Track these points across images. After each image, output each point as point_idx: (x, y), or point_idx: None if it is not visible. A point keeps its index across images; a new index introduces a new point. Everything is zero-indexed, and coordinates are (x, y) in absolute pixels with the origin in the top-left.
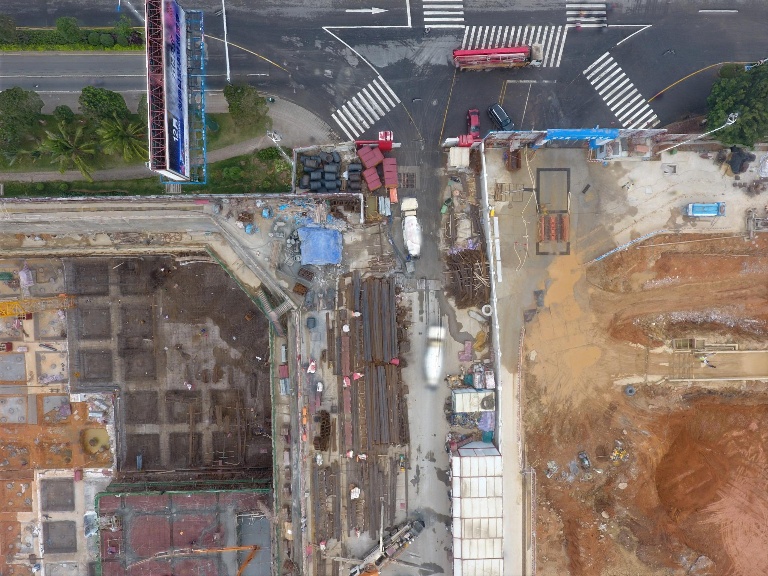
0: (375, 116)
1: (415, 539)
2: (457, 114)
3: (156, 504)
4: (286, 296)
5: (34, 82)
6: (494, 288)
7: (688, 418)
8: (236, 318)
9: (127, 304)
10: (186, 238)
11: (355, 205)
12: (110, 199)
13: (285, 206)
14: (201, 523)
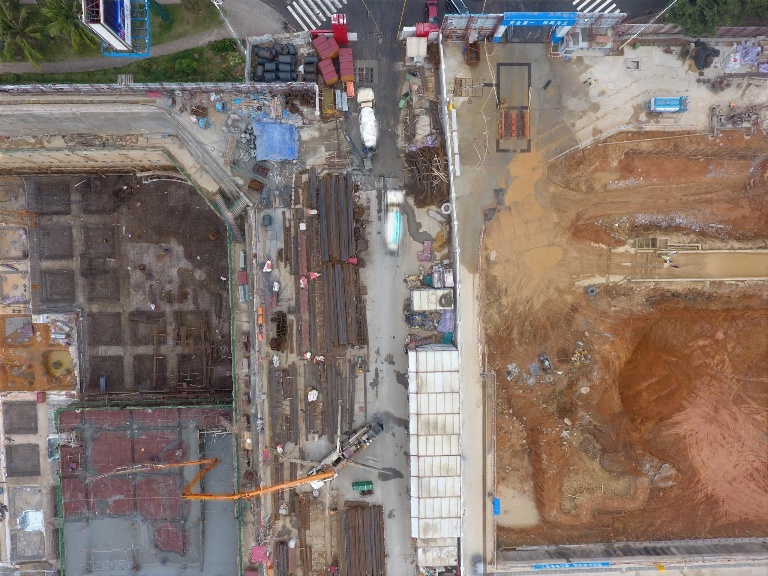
0: (332, 8)
1: (374, 442)
2: (415, 7)
3: (117, 420)
4: (241, 192)
5: None
6: (452, 183)
7: (651, 321)
8: (200, 237)
9: (89, 223)
10: (142, 141)
11: (311, 100)
12: (60, 90)
13: (239, 99)
14: (163, 440)
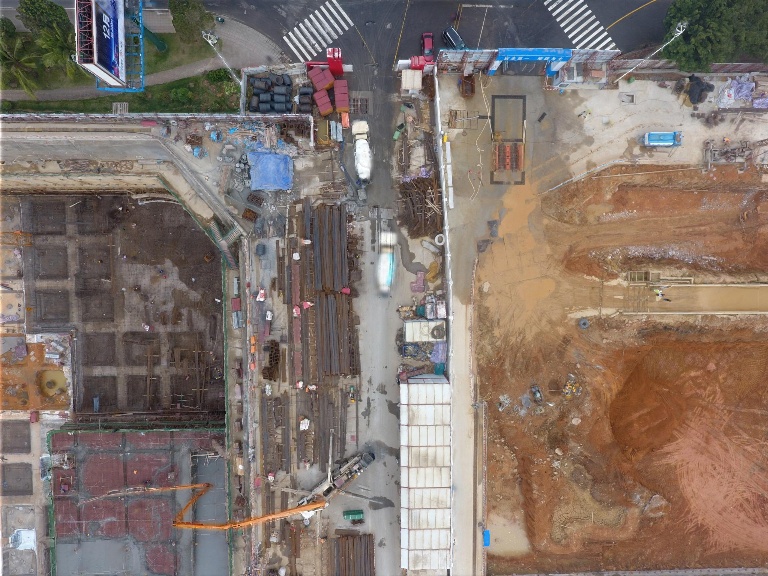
0: (327, 39)
1: (365, 471)
2: (411, 38)
3: (109, 442)
4: (235, 222)
5: None
6: (446, 215)
7: (643, 353)
8: (195, 259)
9: (84, 244)
10: (137, 167)
11: (306, 130)
12: (55, 119)
13: (234, 129)
14: (155, 462)
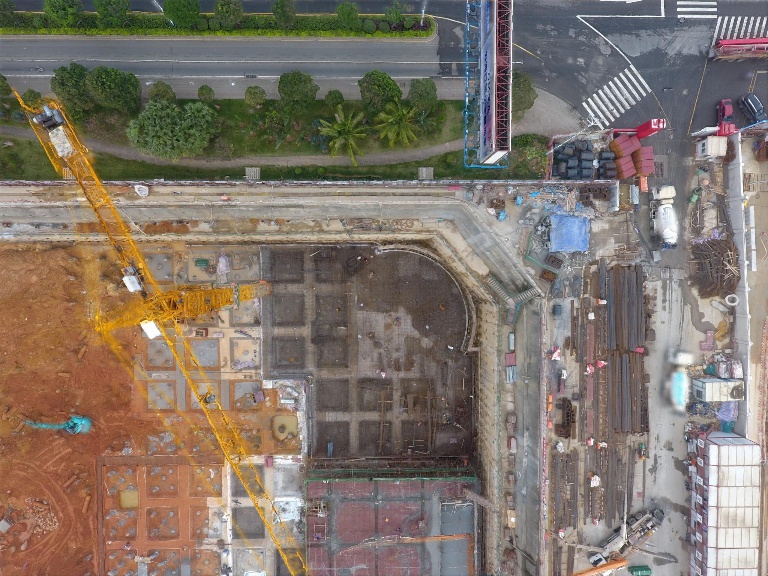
0: (625, 105)
1: None
2: (707, 104)
3: (362, 491)
4: (534, 283)
5: (293, 67)
6: (746, 277)
7: None
8: (430, 307)
9: (321, 292)
10: (417, 225)
11: None
12: (367, 184)
13: (537, 193)
14: (406, 510)
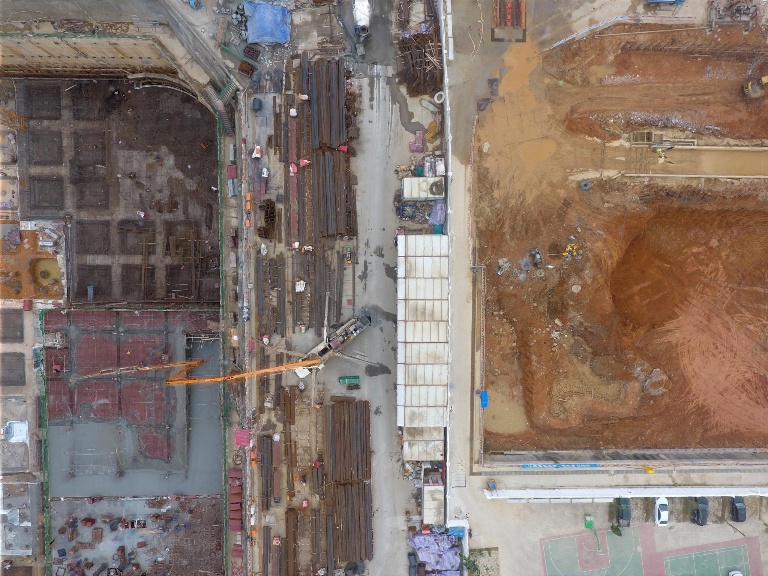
0: None
1: None
2: None
3: (103, 322)
4: (231, 75)
5: None
6: (446, 68)
7: (645, 219)
8: (191, 146)
9: (80, 129)
10: (133, 29)
11: None
12: None
13: None
14: (149, 344)
